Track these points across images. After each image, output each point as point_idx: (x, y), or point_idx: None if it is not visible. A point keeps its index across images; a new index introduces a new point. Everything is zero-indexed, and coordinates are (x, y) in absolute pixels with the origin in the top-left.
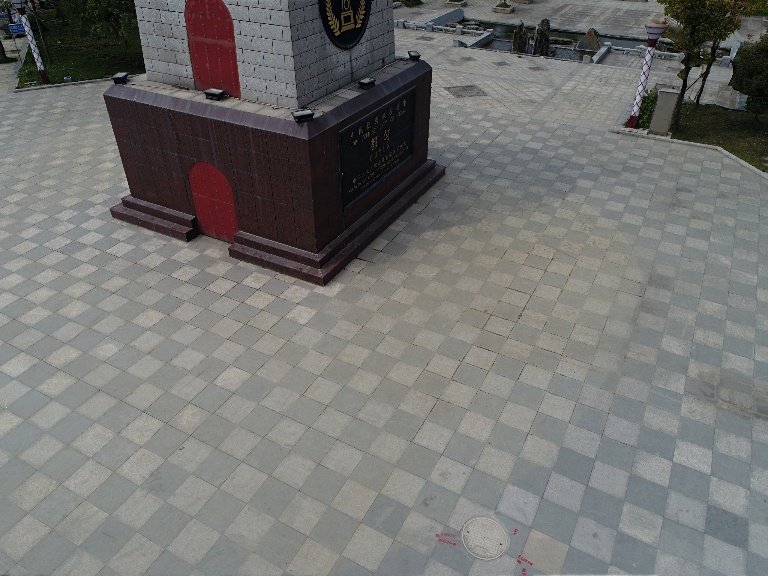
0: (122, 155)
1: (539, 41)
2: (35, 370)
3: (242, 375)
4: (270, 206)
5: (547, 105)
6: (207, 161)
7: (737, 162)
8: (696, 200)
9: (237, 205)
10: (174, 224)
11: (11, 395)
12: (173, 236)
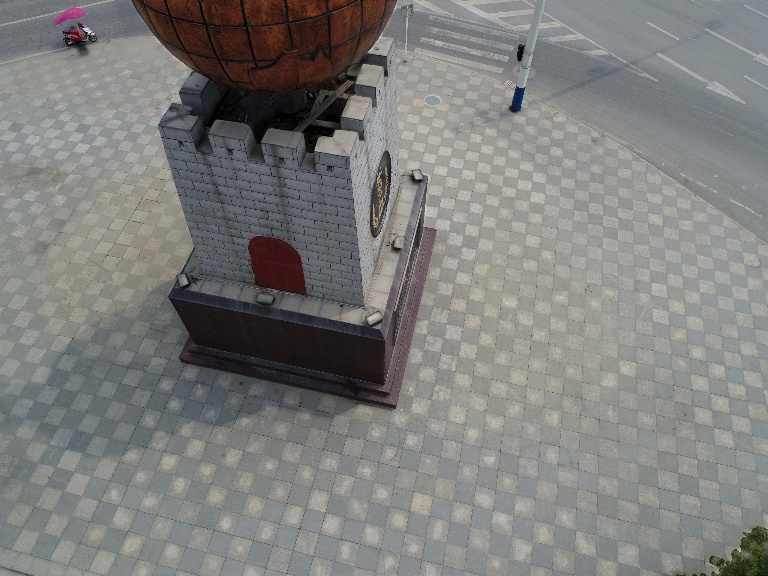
0: None
1: None
2: None
3: None
4: None
5: None
6: None
7: None
8: None
9: None
10: None
11: None
12: None
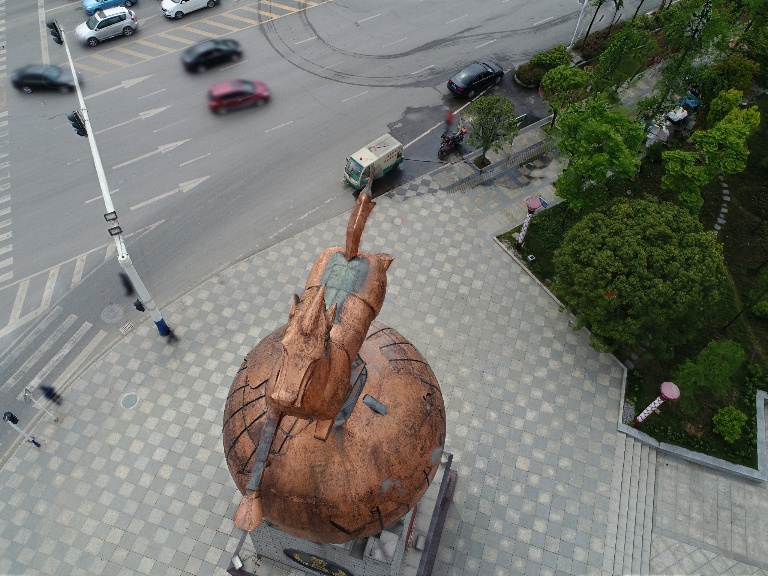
0: None
1: None
2: (156, 465)
3: (148, 570)
4: None
5: None
6: None
7: None
8: None
9: None
10: None
11: (140, 464)
12: None
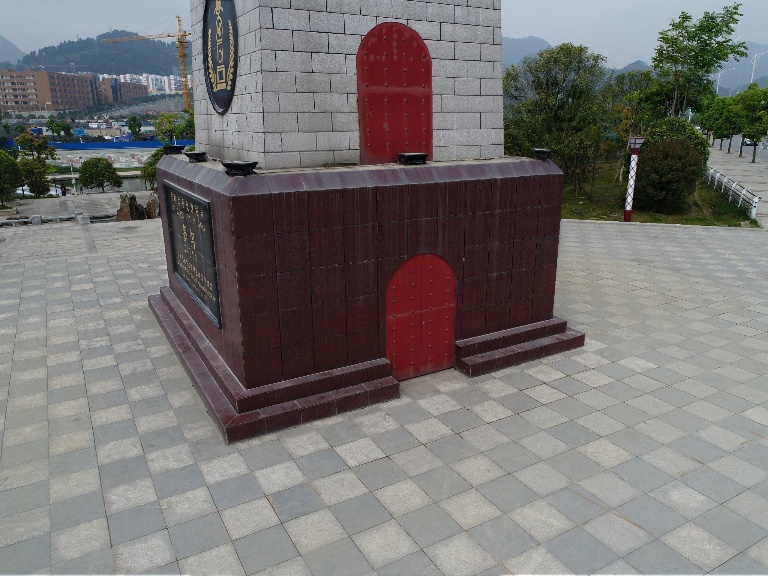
0: (245, 308)
1: None
2: None
3: (760, 411)
4: (506, 281)
5: None
6: (426, 251)
7: None
8: None
9: (460, 302)
10: (362, 385)
11: None
12: (373, 402)
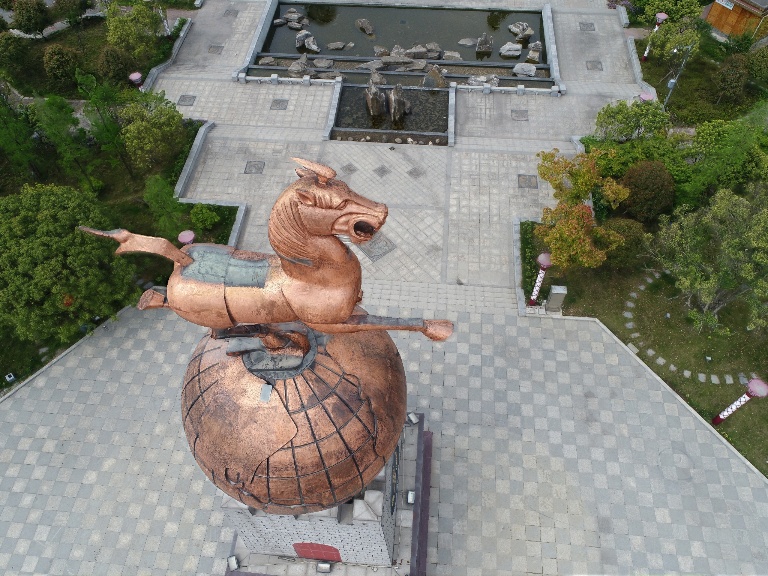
0: None
1: (398, 109)
2: None
3: None
4: None
5: (449, 252)
6: None
7: (611, 337)
8: (600, 408)
9: None
10: None
11: None
12: None
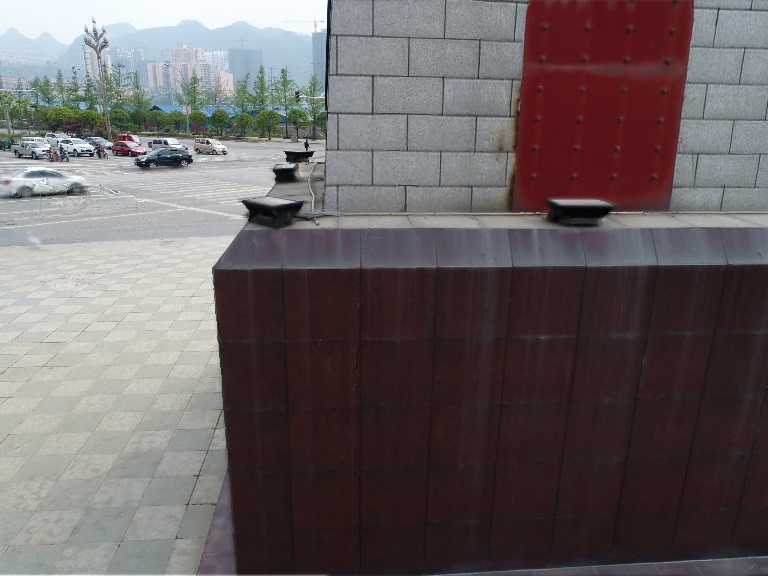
0: None
1: None
2: None
3: None
4: None
5: None
6: None
7: None
8: None
9: None
10: None
11: None
12: None
